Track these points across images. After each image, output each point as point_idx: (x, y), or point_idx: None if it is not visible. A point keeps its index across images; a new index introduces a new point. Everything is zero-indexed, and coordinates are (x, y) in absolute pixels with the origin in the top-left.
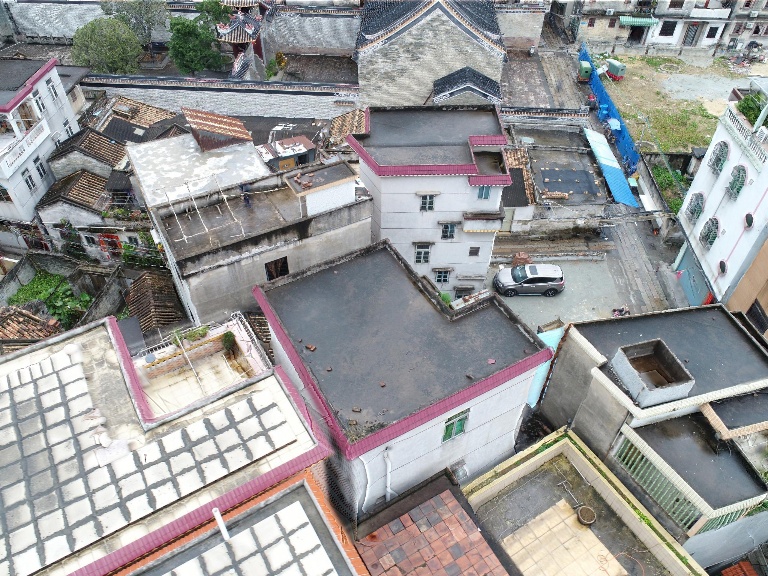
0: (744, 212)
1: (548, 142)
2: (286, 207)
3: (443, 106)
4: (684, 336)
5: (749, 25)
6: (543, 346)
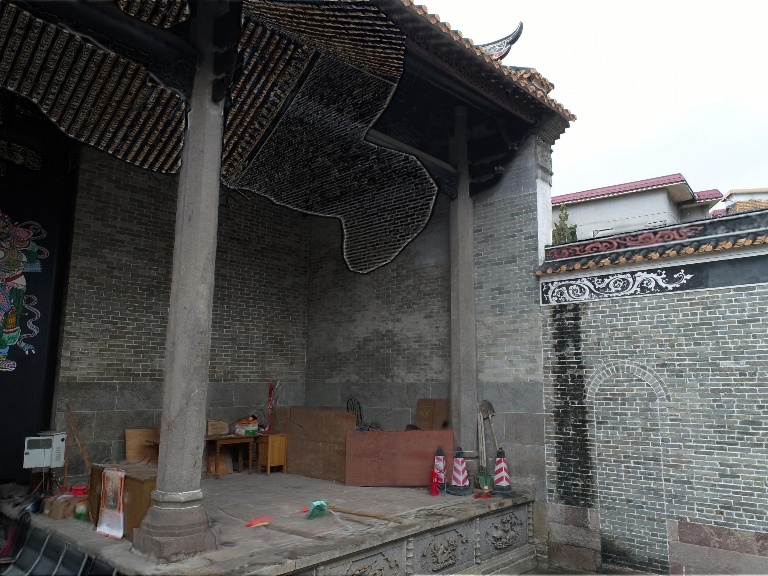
0: None
1: None
2: None
3: (585, 192)
4: None
5: None
6: None
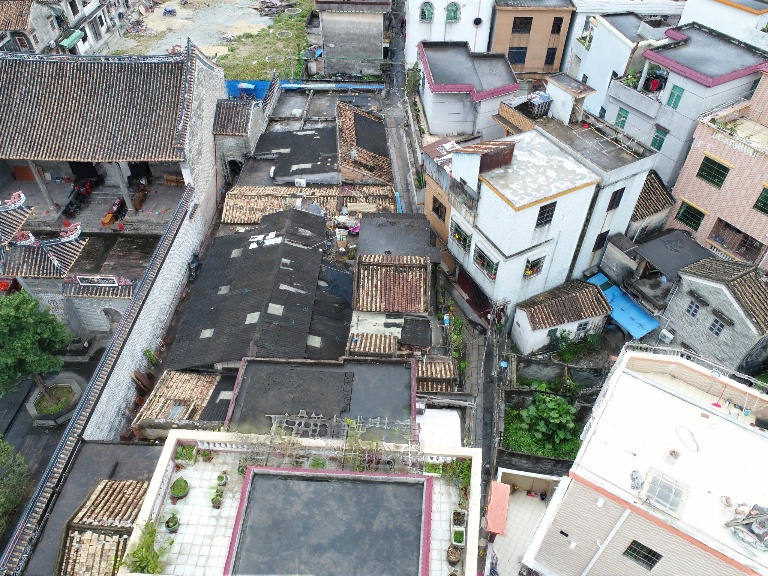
0: (470, 21)
1: (296, 106)
2: (556, 133)
3: None
4: (621, 26)
5: (112, 2)
6: (695, 23)
